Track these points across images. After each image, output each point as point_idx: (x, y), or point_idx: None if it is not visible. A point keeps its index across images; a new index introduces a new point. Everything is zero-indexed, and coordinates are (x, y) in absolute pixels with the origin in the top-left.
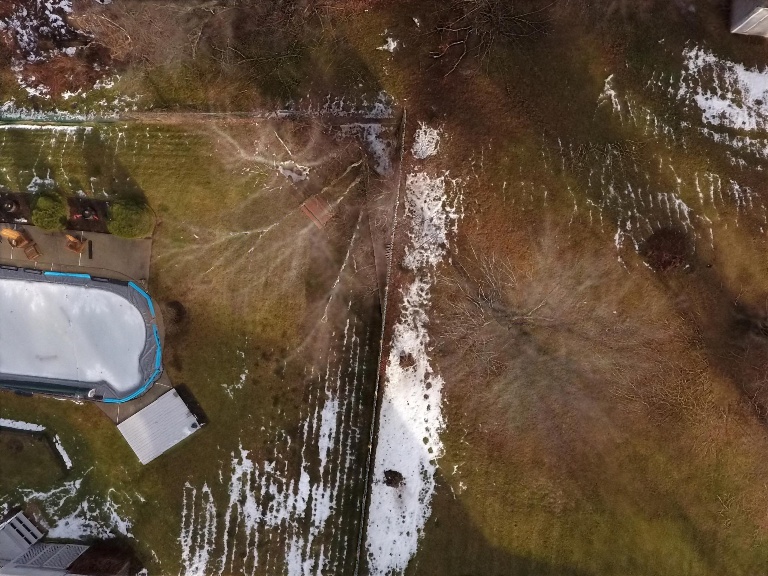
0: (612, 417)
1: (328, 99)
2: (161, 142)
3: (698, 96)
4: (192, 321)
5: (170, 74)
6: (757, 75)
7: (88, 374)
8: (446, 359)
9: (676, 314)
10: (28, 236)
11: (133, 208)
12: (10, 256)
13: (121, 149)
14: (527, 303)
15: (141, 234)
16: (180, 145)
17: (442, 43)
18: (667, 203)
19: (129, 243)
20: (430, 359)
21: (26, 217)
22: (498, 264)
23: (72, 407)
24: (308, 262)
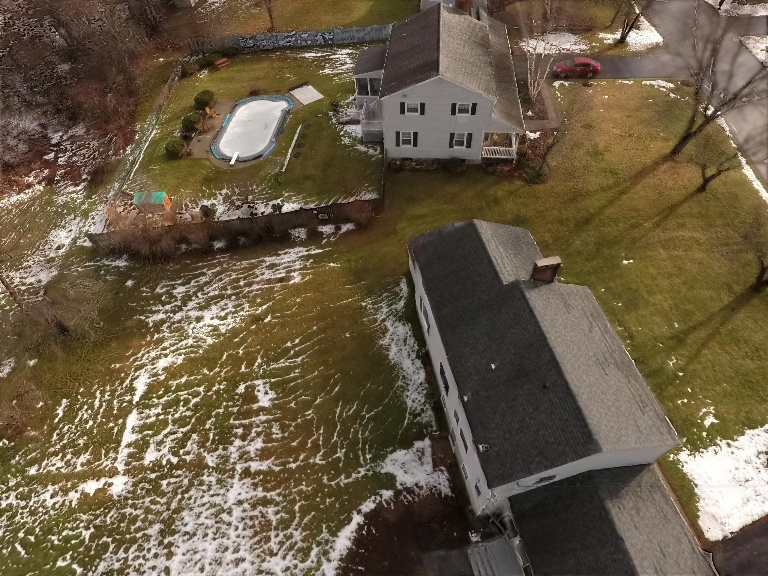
0: (317, 5)
1: None
2: None
3: (212, 8)
4: None
5: None
6: (209, 1)
7: None
8: None
9: (284, 0)
10: None
11: None
12: None
13: None
14: None
15: None
16: None
17: (167, 49)
18: (246, 6)
19: (217, 104)
20: None
21: None
22: None
23: (293, 117)
24: None
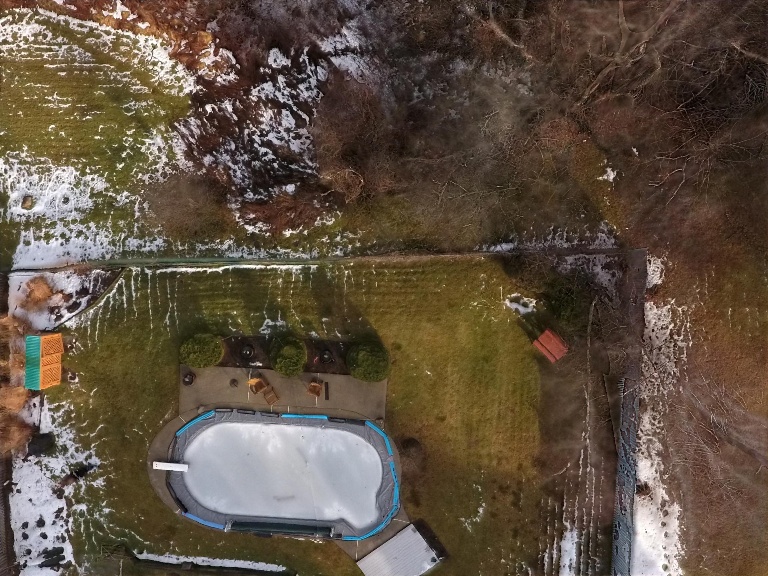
0: None
1: (551, 231)
2: (388, 279)
3: None
4: (428, 457)
5: (392, 209)
6: None
7: (325, 513)
8: (681, 486)
9: None
10: (265, 380)
11: (380, 355)
12: (246, 400)
13: (350, 288)
14: (759, 428)
15: (385, 378)
16: (408, 282)
17: (662, 172)
18: None
19: (365, 383)
20: (665, 487)
21: (261, 361)
22: (728, 391)
23: (311, 546)
24: (539, 394)
